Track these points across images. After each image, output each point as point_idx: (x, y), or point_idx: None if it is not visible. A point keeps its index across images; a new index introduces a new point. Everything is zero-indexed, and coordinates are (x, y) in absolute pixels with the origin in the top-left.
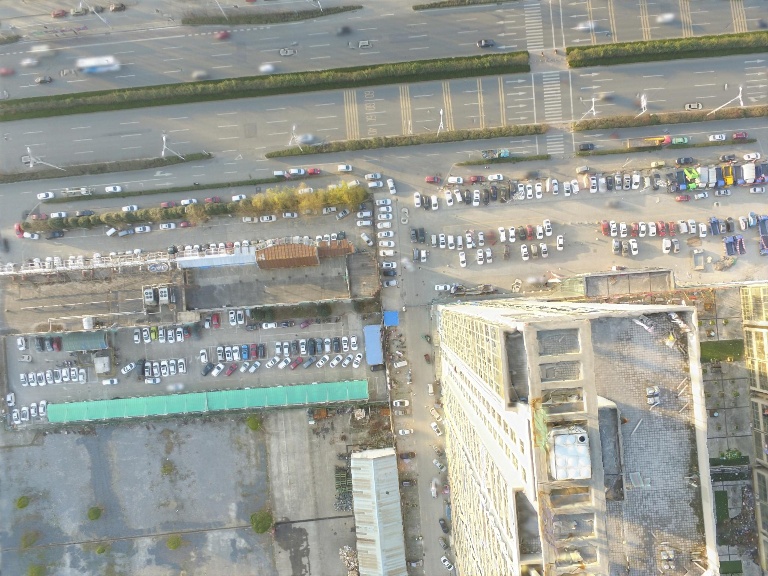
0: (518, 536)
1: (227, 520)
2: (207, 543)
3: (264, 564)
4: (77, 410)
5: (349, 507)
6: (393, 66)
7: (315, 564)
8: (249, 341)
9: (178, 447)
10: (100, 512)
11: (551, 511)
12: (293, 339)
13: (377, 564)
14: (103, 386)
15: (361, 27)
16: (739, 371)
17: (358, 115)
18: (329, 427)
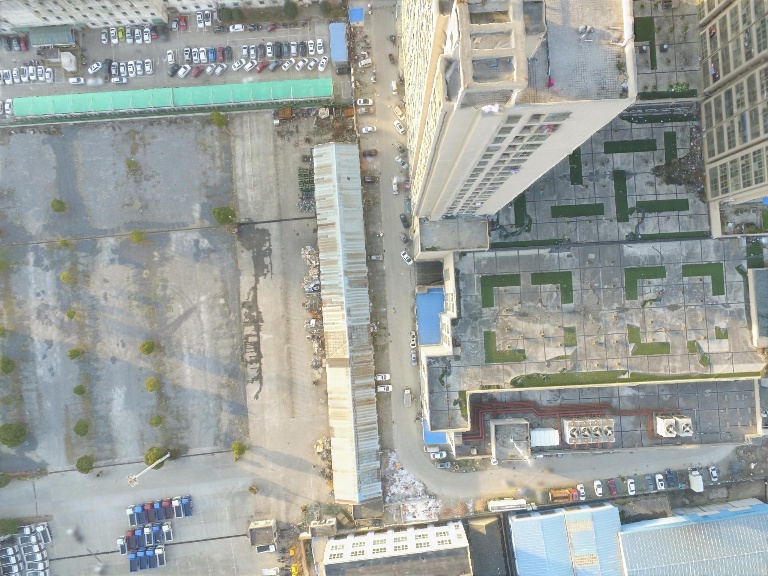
0: None
1: (191, 220)
2: (170, 243)
3: (226, 264)
4: (43, 103)
5: (312, 208)
6: None
7: (277, 264)
8: (216, 44)
9: (143, 148)
10: (64, 206)
11: None
12: (260, 42)
13: (337, 246)
14: (70, 86)
15: None
16: (689, 8)
17: None
18: (294, 130)
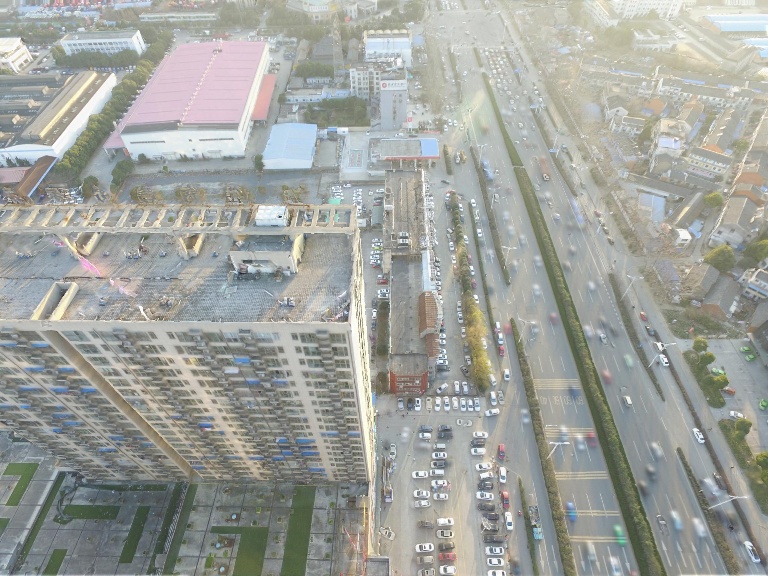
0: (223, 223)
1: None
2: None
3: None
4: None
5: None
6: (611, 420)
7: None
8: None
9: None
10: None
11: (241, 209)
12: None
13: None
14: None
15: (644, 399)
16: None
17: (558, 389)
18: None
